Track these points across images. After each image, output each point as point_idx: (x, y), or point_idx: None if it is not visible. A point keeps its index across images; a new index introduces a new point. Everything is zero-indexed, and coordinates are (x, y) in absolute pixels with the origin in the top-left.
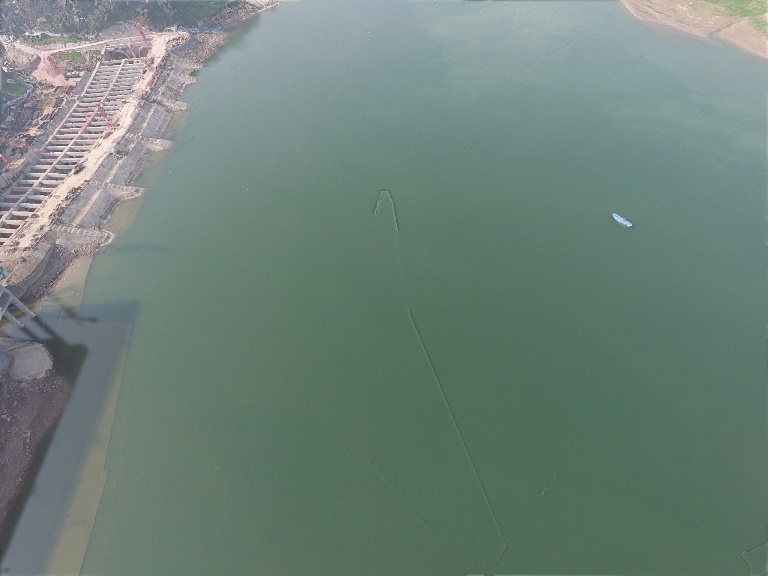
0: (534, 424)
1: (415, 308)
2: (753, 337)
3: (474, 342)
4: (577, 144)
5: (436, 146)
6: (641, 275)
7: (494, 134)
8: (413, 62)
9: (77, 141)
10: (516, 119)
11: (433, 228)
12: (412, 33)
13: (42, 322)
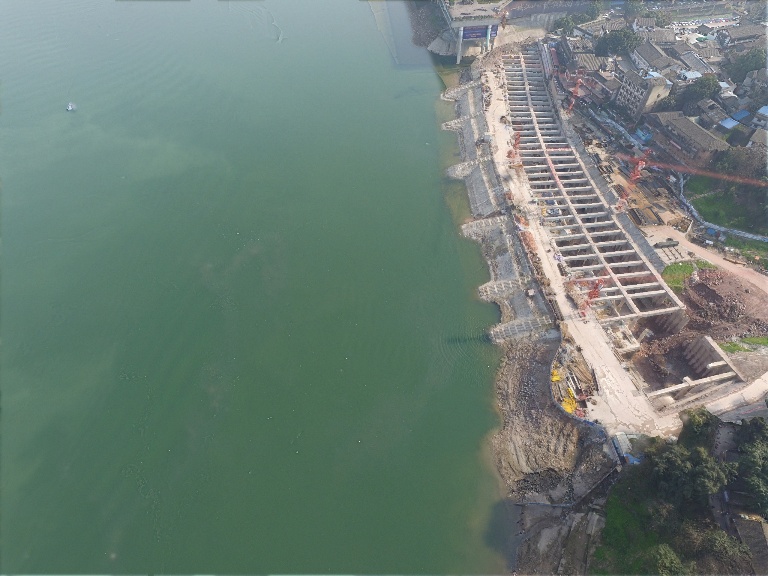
0: (201, 47)
1: (236, 75)
2: (76, 55)
3: (211, 68)
4: (20, 175)
5: (160, 174)
6: (99, 71)
7: (90, 189)
8: (100, 318)
9: (541, 150)
10: (46, 210)
11: (204, 103)
12: (26, 480)
13: (450, 61)
